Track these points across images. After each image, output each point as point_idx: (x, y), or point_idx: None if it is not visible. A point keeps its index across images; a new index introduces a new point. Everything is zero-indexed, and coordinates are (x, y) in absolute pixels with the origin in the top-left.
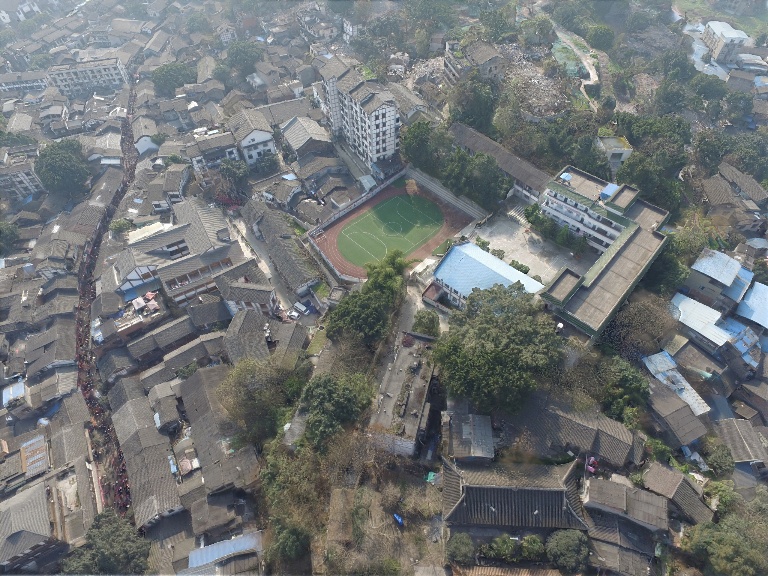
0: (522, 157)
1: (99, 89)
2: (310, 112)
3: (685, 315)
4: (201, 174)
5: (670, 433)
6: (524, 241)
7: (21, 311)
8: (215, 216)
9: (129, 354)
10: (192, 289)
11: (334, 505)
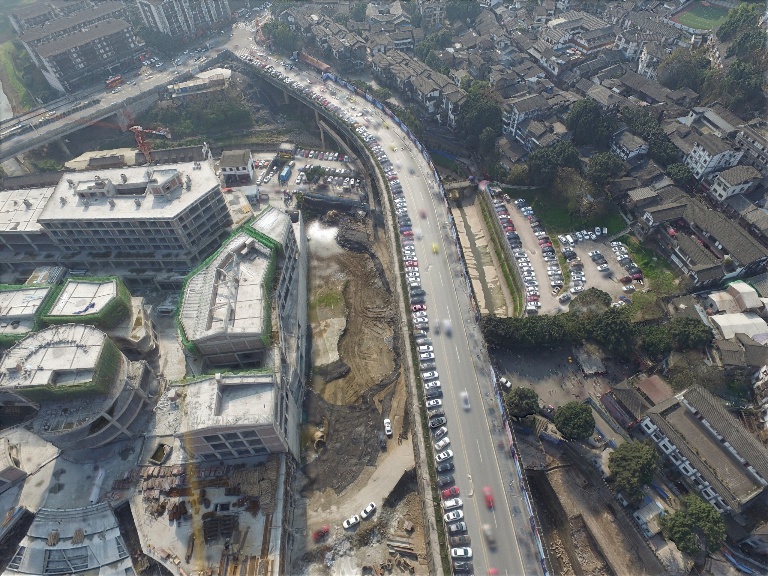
0: None
1: None
2: None
3: None
4: (568, 1)
5: None
6: None
7: None
8: None
9: None
10: (596, 47)
11: None
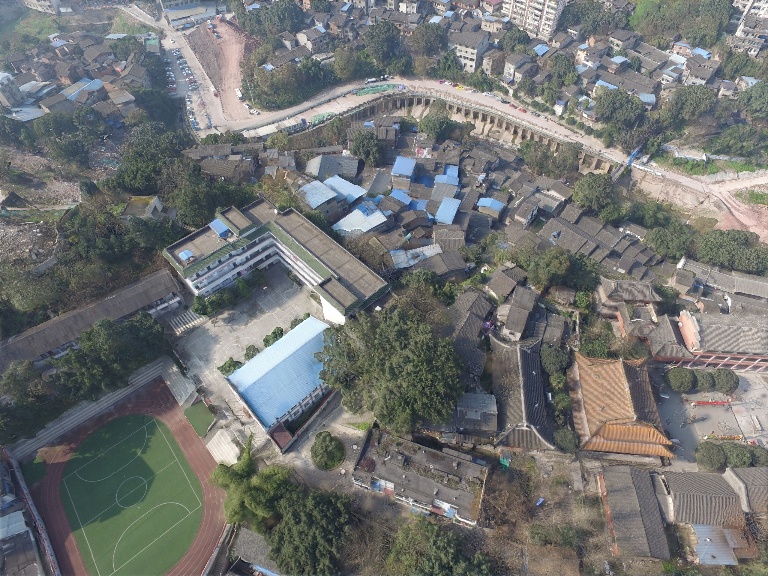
0: (106, 294)
1: None
2: None
3: None
4: None
5: (457, 272)
6: (226, 328)
7: None
8: None
9: None
10: None
11: (546, 570)
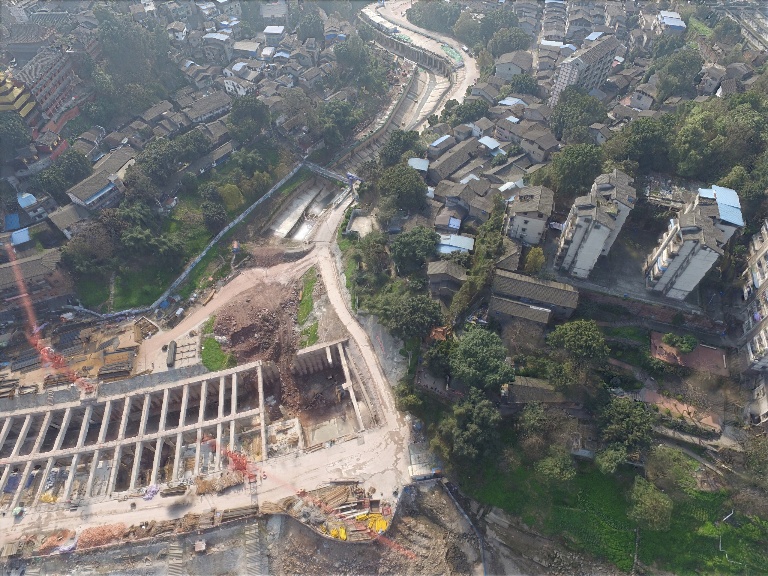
0: None
1: None
2: None
3: None
4: None
5: None
6: None
7: None
8: None
9: None
10: None
11: None
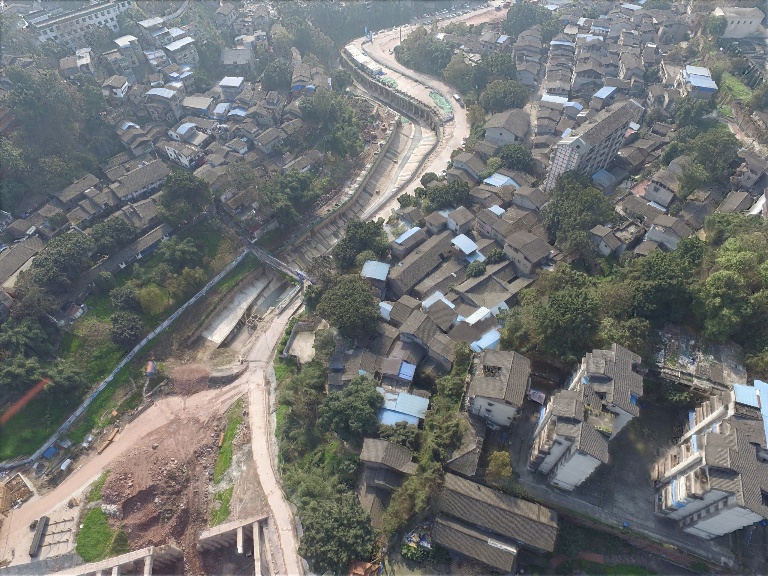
0: None
1: None
2: None
3: (120, 40)
4: None
5: None
6: None
7: None
8: None
9: None
10: None
11: None
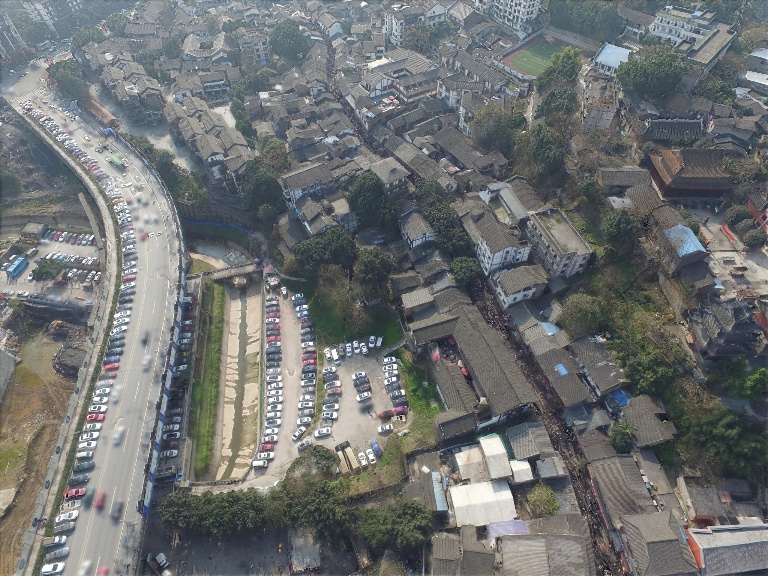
0: None
1: (274, 1)
2: (461, 1)
3: (748, 77)
4: (399, 35)
5: None
6: None
7: (310, 106)
8: (421, 55)
9: (388, 128)
10: (418, 94)
11: (576, 140)
